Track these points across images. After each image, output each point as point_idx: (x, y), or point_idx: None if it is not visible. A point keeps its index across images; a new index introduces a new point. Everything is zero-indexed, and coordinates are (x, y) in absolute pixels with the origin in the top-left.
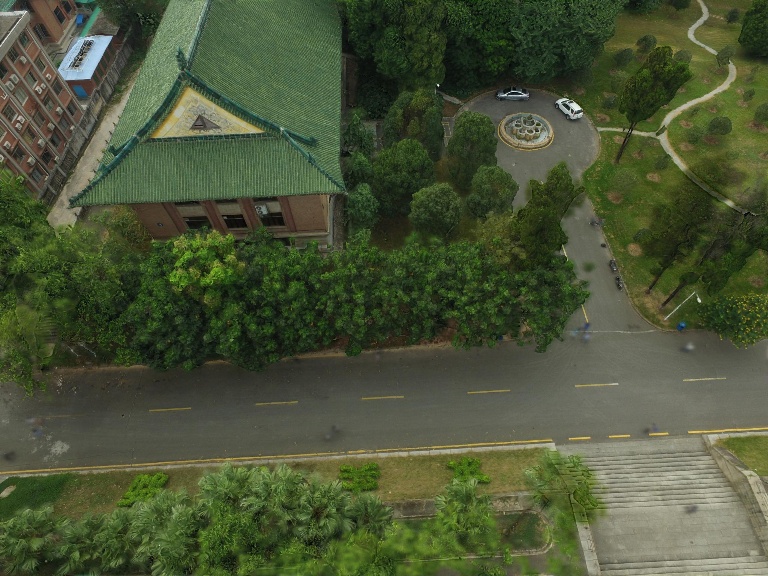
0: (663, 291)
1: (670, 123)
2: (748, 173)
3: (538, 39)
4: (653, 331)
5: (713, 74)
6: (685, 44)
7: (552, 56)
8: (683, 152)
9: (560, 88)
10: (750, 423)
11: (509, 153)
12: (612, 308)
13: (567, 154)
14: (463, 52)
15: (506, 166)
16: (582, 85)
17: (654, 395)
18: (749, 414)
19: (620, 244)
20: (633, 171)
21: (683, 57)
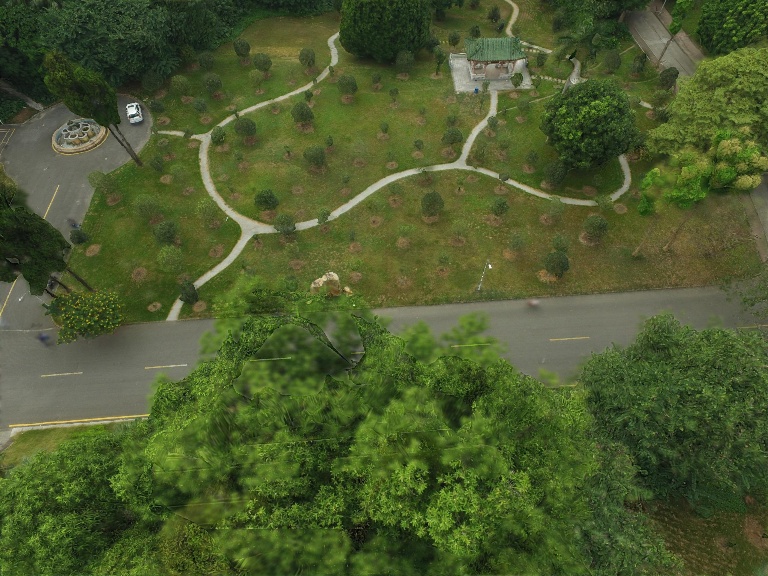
0: (85, 290)
1: (225, 125)
2: (261, 172)
3: (69, 46)
4: (51, 329)
5: (303, 76)
6: (315, 46)
7: (94, 62)
8: (215, 153)
9: (145, 92)
10: (72, 415)
11: (49, 158)
12: (31, 307)
13: (104, 158)
14: (9, 60)
15: (38, 171)
16: (149, 89)
17: (3, 391)
18: (78, 407)
19: (84, 245)
20: (151, 173)
21: (256, 60)
